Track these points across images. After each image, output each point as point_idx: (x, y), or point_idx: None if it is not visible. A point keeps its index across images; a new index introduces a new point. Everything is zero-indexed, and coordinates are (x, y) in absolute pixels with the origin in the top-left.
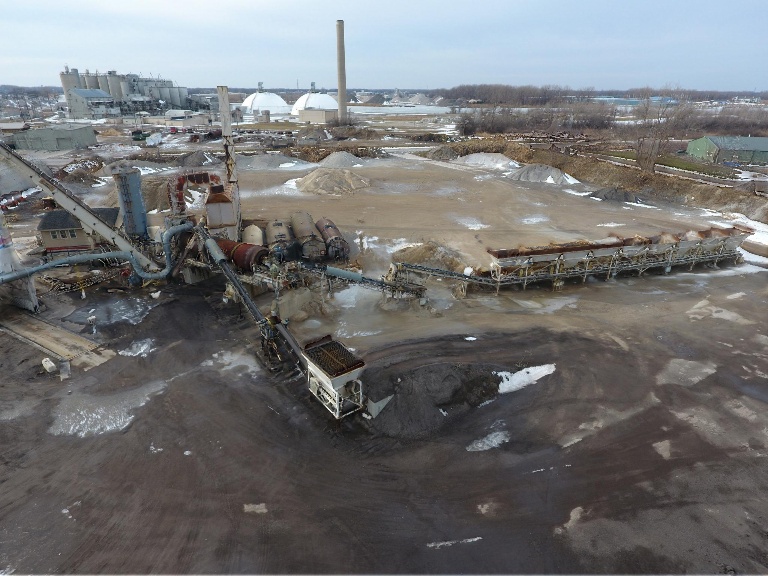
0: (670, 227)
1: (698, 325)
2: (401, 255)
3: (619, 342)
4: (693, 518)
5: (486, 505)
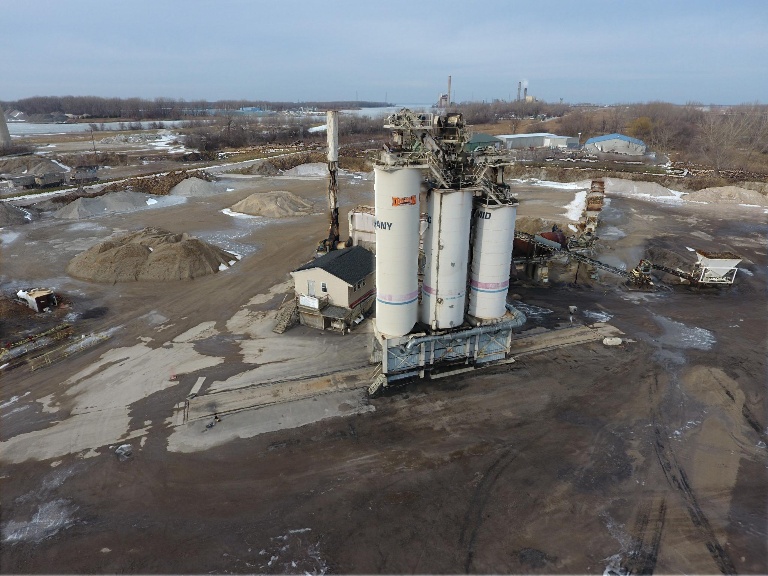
0: (534, 190)
1: None
2: None
3: (670, 234)
4: None
5: None
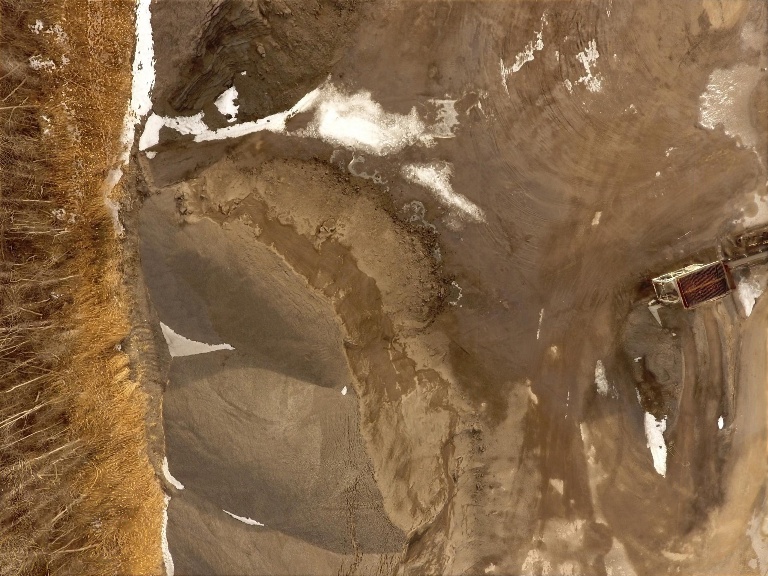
0: None
1: None
2: None
3: (676, 555)
4: (511, 458)
5: (556, 351)
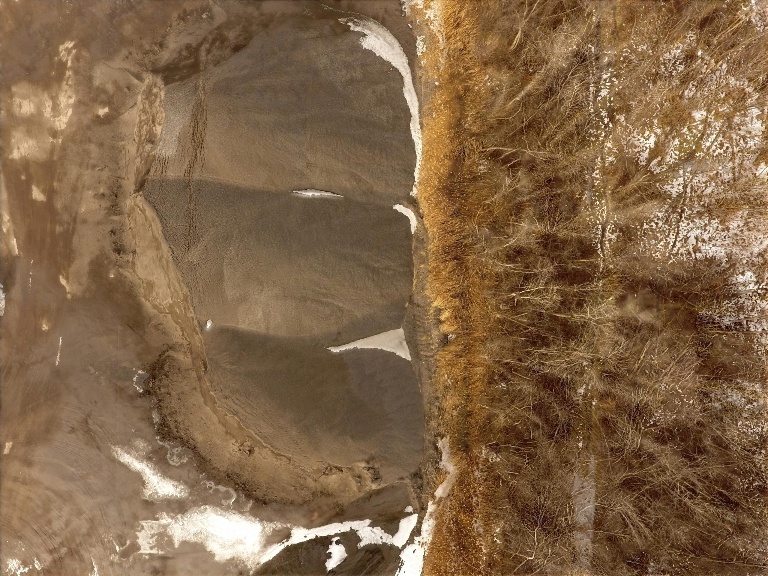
0: None
1: None
2: None
3: None
4: (84, 223)
5: (43, 325)
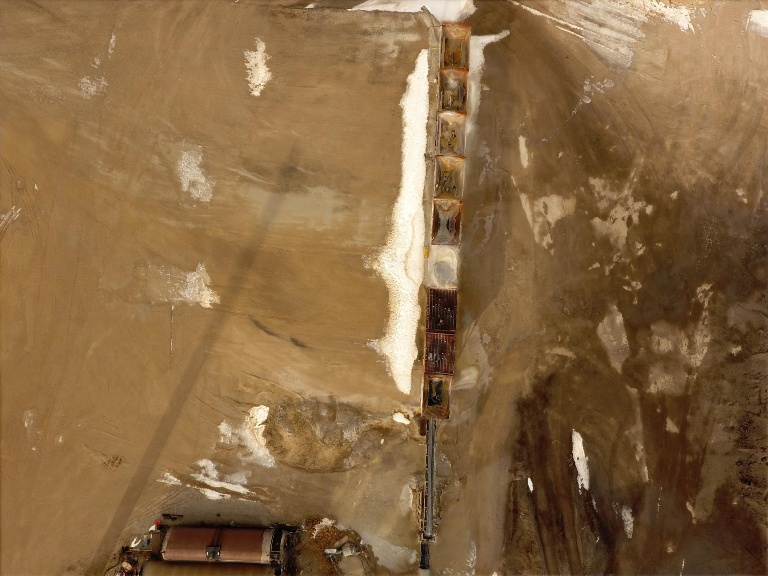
0: None
1: (561, 257)
2: (300, 461)
3: (563, 354)
4: (713, 454)
5: (669, 548)
